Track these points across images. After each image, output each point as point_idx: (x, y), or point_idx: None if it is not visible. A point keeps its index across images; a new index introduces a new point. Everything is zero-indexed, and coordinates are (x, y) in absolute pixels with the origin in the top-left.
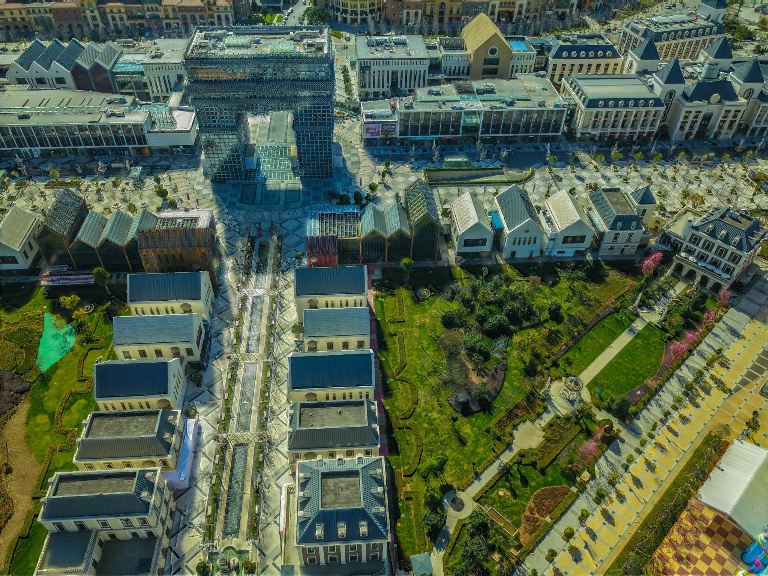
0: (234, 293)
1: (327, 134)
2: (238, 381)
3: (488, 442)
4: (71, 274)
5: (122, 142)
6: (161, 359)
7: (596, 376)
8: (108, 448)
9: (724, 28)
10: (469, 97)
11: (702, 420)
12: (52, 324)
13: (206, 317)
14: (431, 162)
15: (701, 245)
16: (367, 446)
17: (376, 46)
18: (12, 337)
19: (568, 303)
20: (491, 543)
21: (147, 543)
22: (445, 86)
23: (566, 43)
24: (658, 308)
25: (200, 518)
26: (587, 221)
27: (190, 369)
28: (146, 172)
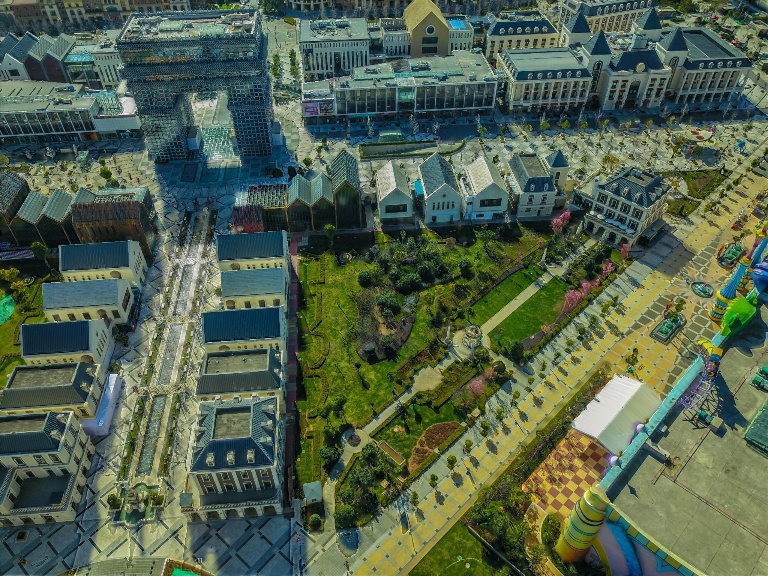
0: (167, 263)
1: (261, 113)
2: (163, 340)
3: (389, 386)
4: (13, 250)
5: (71, 128)
6: (85, 320)
7: (498, 325)
8: (29, 397)
9: (668, 2)
10: (404, 74)
11: (592, 361)
12: None
13: (136, 284)
14: (367, 138)
15: (608, 203)
16: (269, 389)
17: (319, 29)
18: None
19: (477, 260)
20: (377, 470)
21: (62, 480)
22: (382, 65)
23: (504, 20)
24: (566, 263)
25: (117, 460)
26: (502, 185)
27: (117, 330)
28: (94, 156)
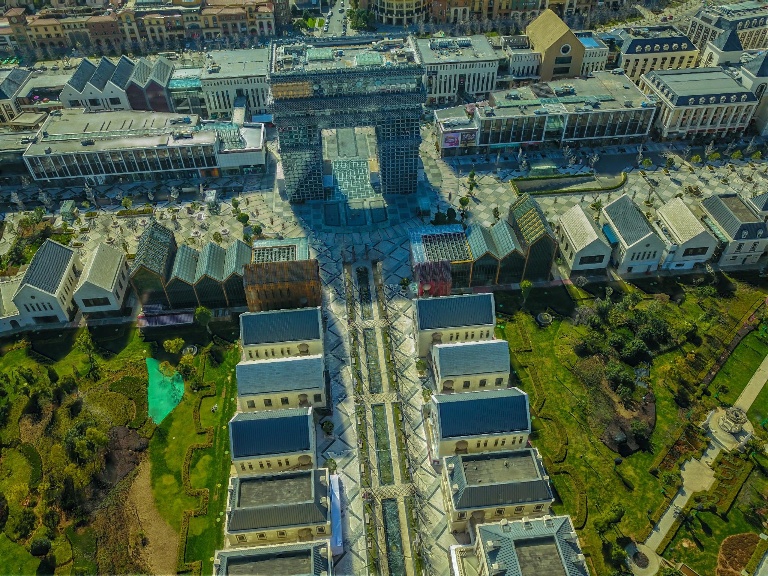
0: (342, 326)
1: (414, 148)
2: (369, 426)
3: (656, 485)
4: (168, 314)
5: (191, 164)
6: (295, 410)
7: (753, 404)
8: (262, 517)
9: None
10: (550, 100)
11: None
12: (157, 370)
13: None
14: (516, 171)
15: None
16: (540, 501)
17: (440, 49)
18: (118, 387)
19: (707, 323)
20: None
21: None
22: (521, 89)
23: (637, 37)
24: None
25: None
26: (709, 231)
27: None
28: (219, 195)
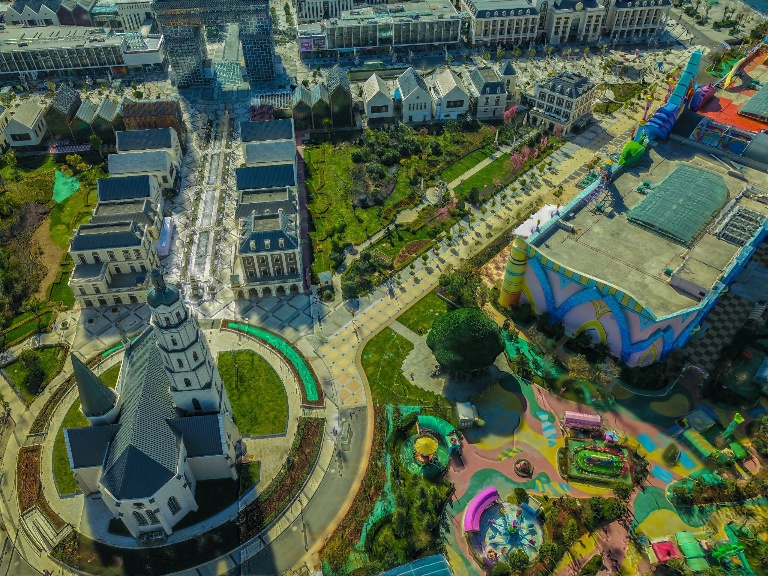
0: (198, 153)
1: (266, 42)
2: (202, 200)
3: (378, 221)
4: (72, 145)
5: (104, 63)
6: None
7: None
8: None
9: None
10: (383, 15)
11: None
12: (61, 177)
13: (176, 164)
14: (354, 67)
15: (547, 99)
16: None
17: None
18: (33, 184)
19: (444, 141)
20: (371, 262)
21: (141, 274)
22: (365, 9)
23: None
24: None
25: None
26: (464, 89)
27: (166, 193)
28: (125, 85)
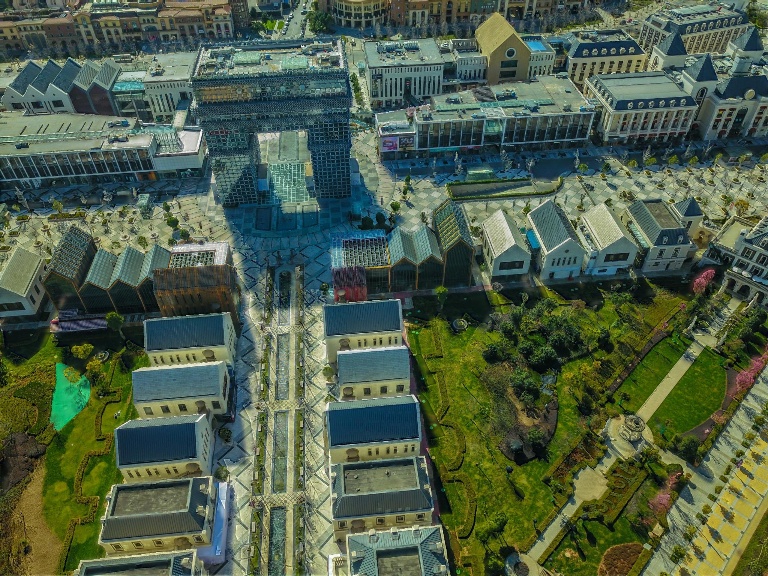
0: (257, 332)
1: (344, 152)
2: (269, 433)
3: (547, 494)
4: (82, 319)
5: (127, 168)
6: (187, 417)
7: (656, 412)
8: (136, 526)
9: None
10: (490, 104)
11: None
12: None
13: (230, 362)
14: (453, 175)
15: (755, 259)
16: (420, 510)
17: (387, 52)
18: (23, 393)
19: (618, 330)
20: None
21: None
22: (463, 93)
23: (585, 40)
24: (713, 330)
25: None
26: (630, 237)
27: (217, 423)
28: (154, 199)
